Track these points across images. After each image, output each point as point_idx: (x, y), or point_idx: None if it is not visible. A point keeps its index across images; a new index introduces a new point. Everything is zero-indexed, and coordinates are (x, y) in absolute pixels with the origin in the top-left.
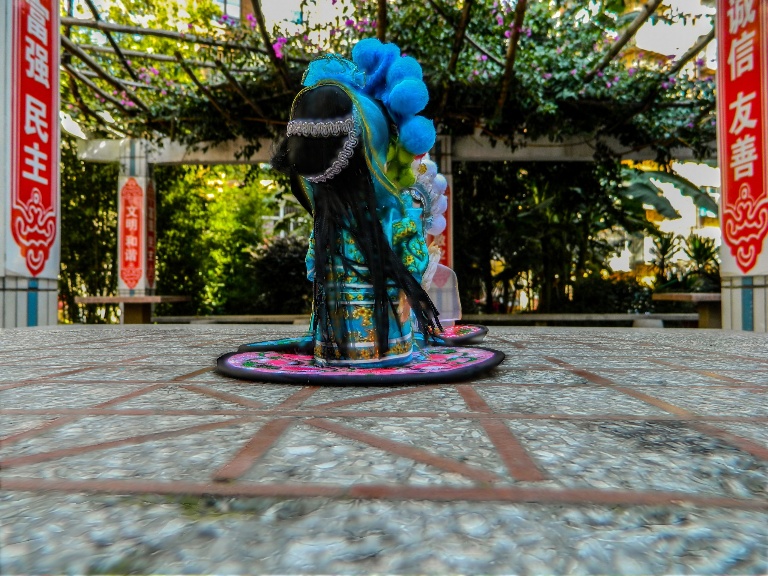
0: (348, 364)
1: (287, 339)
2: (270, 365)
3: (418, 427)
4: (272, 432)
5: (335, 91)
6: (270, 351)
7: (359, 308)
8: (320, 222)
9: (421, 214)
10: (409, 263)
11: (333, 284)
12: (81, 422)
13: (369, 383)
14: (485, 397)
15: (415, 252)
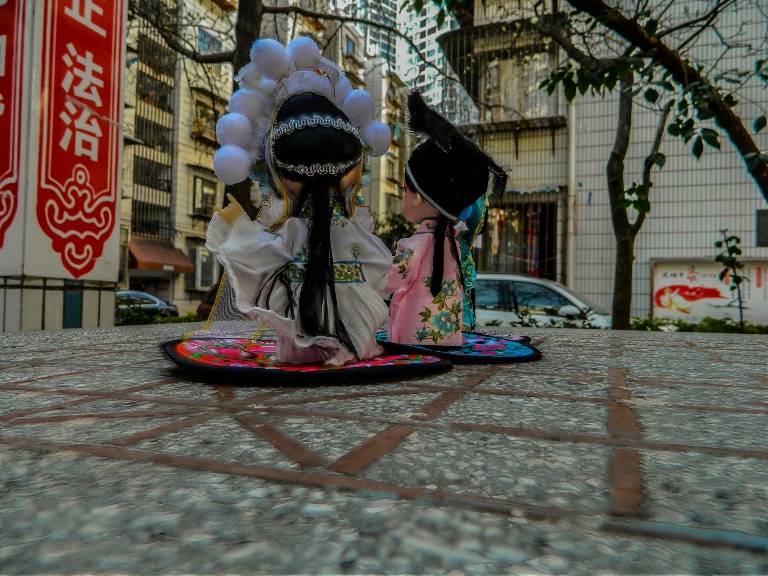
0: None
1: (491, 355)
2: None
3: None
4: None
5: None
6: None
7: None
8: None
9: None
10: None
11: None
12: None
13: None
14: None
15: None
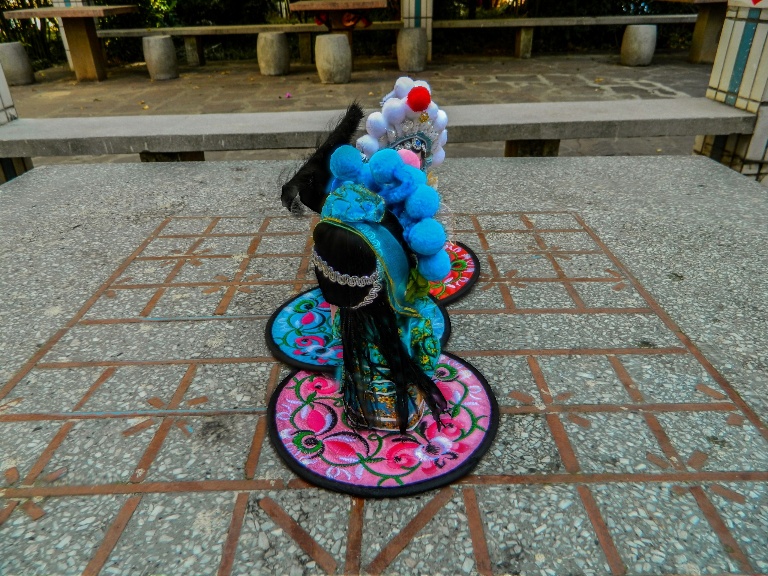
0: (375, 429)
1: (301, 299)
2: (314, 441)
3: None
4: None
5: (359, 246)
6: (300, 372)
7: (383, 397)
8: (345, 324)
9: (422, 160)
10: (425, 362)
11: (361, 381)
12: None
13: (399, 496)
14: (486, 530)
15: (430, 352)
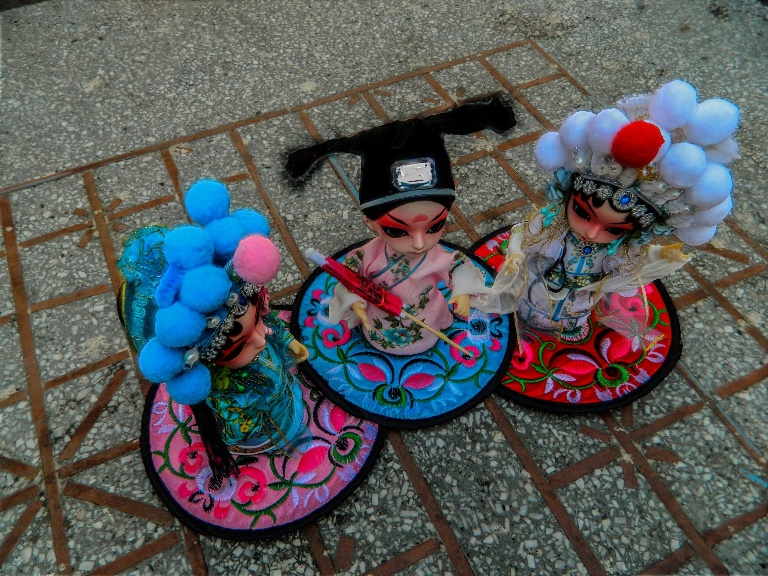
0: None
1: None
2: None
3: (29, 566)
4: (7, 502)
5: None
6: (289, 312)
7: None
8: None
9: (631, 224)
10: (223, 431)
11: None
12: (12, 407)
13: None
14: (128, 571)
15: (227, 430)
